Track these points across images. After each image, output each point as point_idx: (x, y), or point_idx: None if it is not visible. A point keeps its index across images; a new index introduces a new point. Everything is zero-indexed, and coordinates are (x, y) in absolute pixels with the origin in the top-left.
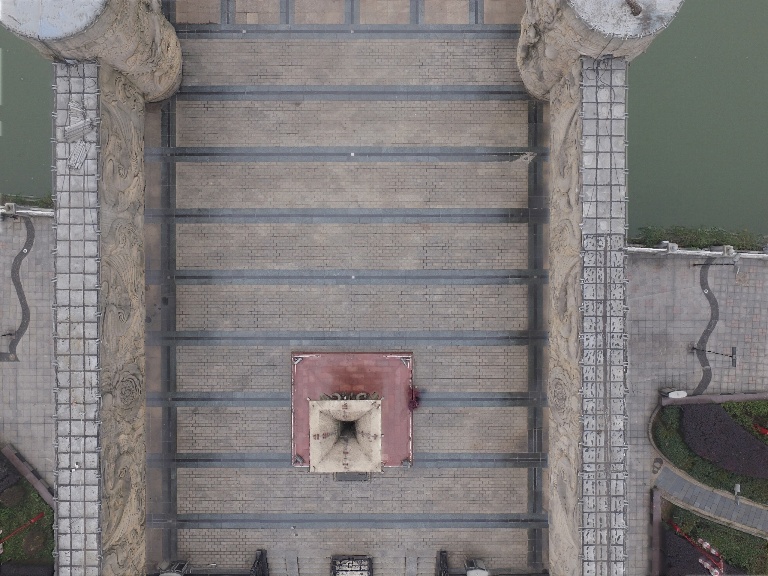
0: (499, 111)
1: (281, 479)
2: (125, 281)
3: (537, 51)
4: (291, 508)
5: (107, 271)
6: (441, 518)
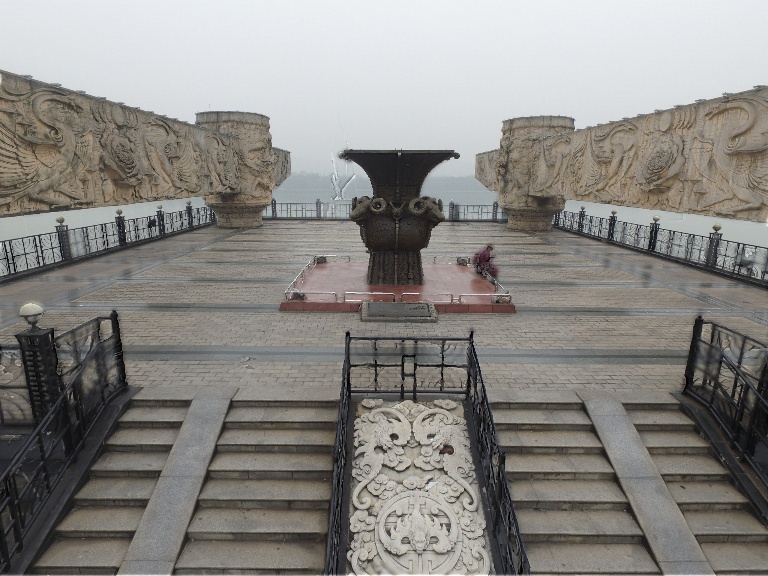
0: (500, 232)
1: (251, 319)
2: (182, 160)
3: (509, 172)
4: (256, 340)
5: (183, 132)
6: (627, 354)
